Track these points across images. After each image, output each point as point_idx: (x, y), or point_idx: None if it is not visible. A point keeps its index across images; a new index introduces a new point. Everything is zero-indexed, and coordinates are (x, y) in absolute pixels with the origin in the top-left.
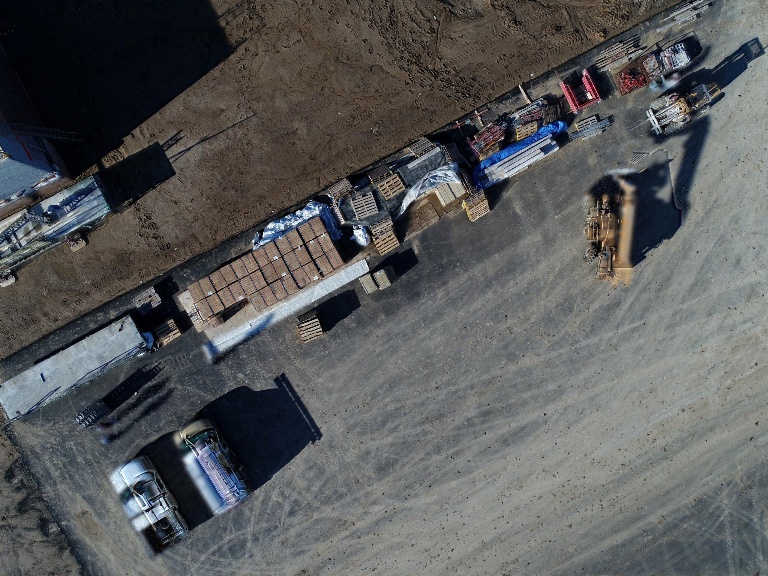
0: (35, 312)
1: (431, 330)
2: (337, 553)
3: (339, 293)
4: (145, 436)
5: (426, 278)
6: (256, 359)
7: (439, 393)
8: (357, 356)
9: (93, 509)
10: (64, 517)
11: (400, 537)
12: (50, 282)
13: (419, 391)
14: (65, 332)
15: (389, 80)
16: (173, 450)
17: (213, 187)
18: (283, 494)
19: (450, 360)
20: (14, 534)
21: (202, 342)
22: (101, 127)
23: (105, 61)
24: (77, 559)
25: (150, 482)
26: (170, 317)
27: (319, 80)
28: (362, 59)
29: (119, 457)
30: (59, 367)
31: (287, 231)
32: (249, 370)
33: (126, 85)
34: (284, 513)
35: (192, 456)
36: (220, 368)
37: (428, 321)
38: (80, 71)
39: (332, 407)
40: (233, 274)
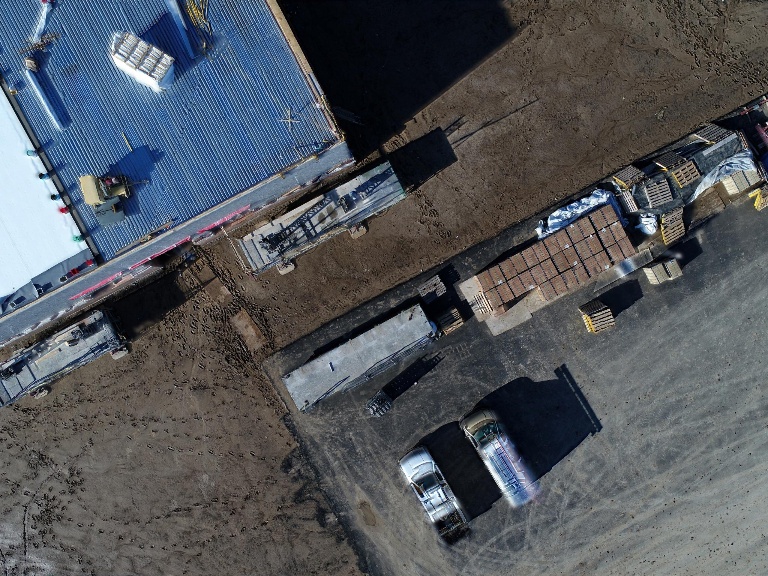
0: (314, 300)
1: (714, 321)
2: (615, 546)
3: (622, 283)
4: (424, 427)
5: (710, 268)
6: (537, 349)
7: (721, 385)
8: (639, 347)
9: (371, 500)
10: (342, 507)
11: (679, 530)
12: (329, 270)
13: (701, 383)
14: (345, 321)
15: (675, 64)
16: (452, 441)
17: (495, 174)
18: (562, 486)
19: (733, 352)
20: (289, 524)
21: (483, 332)
22: (383, 112)
23: (388, 44)
24: (354, 550)
25: (429, 473)
26: (452, 306)
27: (604, 64)
28: (648, 43)
29: (398, 448)
30: (348, 356)
31: (572, 219)
32: (529, 360)
33: (409, 69)
34: (563, 505)
35: (471, 447)
36: (500, 358)
37: (711, 312)
38: (363, 54)
39: (612, 399)
40: (524, 263)
